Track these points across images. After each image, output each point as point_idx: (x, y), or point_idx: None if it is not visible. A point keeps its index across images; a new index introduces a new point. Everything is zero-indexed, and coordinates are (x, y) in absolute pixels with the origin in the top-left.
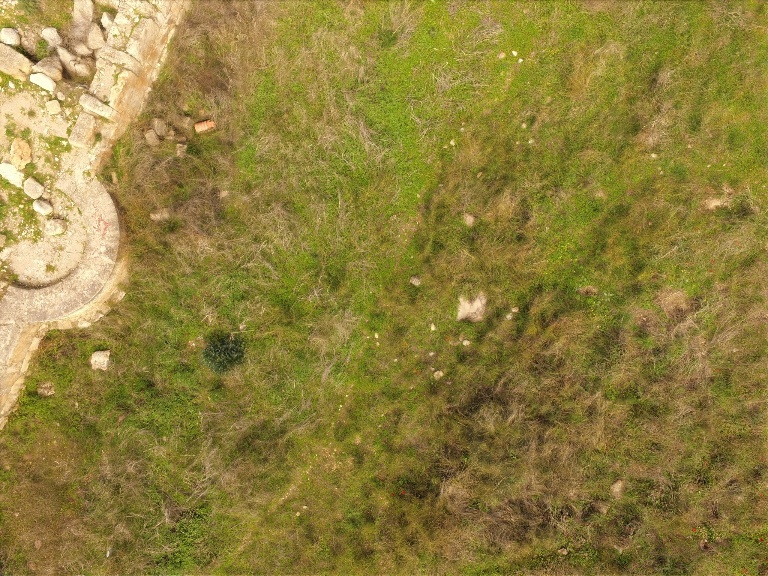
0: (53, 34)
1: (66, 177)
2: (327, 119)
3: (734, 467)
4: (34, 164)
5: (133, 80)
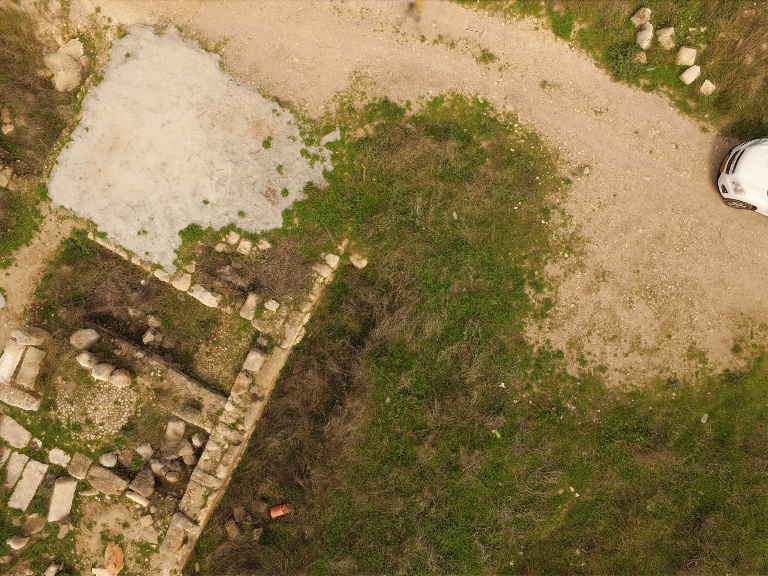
0: (147, 450)
1: (154, 574)
2: (401, 555)
3: None
4: (126, 566)
5: (219, 491)
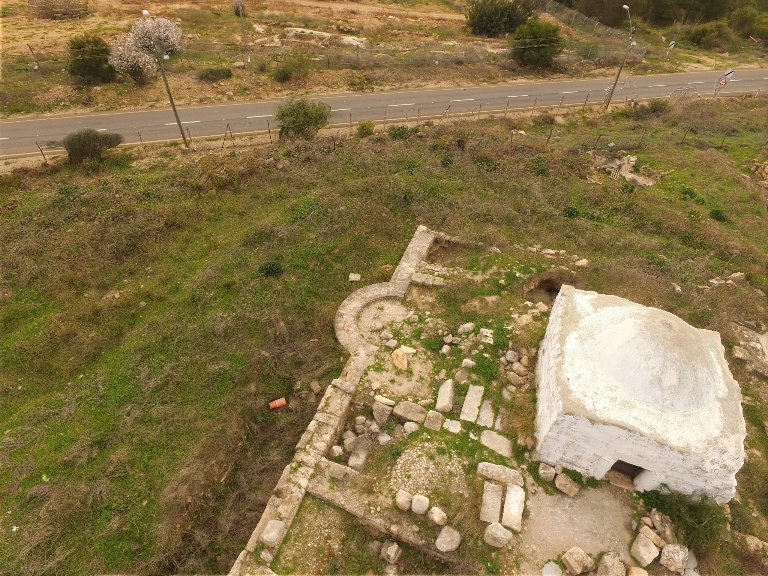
0: None
1: None
2: None
3: (0, 237)
4: None
5: None
